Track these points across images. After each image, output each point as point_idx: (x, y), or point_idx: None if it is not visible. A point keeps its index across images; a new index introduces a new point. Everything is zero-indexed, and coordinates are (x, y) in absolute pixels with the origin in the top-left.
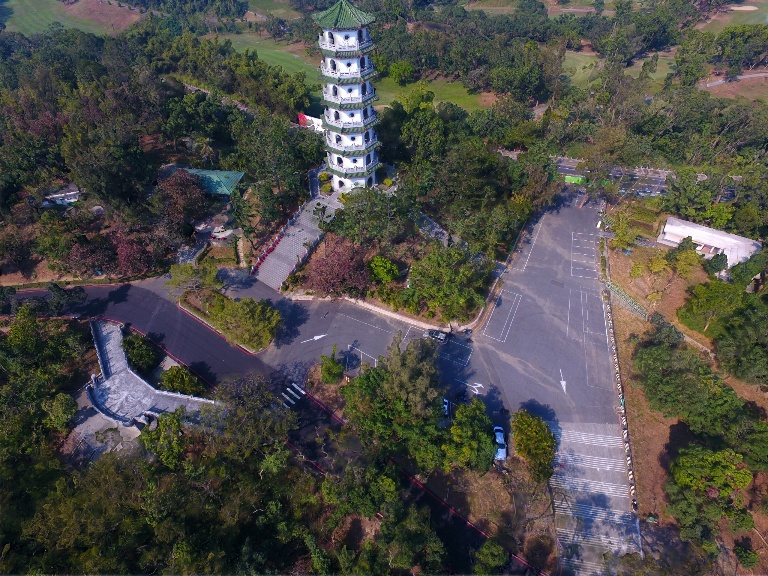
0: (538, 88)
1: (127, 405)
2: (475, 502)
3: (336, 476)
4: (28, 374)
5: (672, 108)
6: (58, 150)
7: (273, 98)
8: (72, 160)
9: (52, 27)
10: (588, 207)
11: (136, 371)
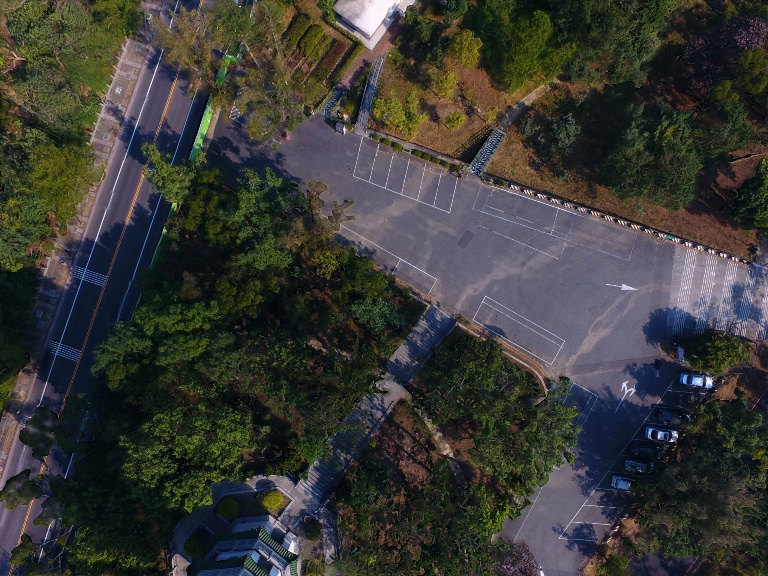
0: None
1: None
2: None
3: None
4: None
5: None
6: None
7: None
8: None
9: None
10: None
11: None
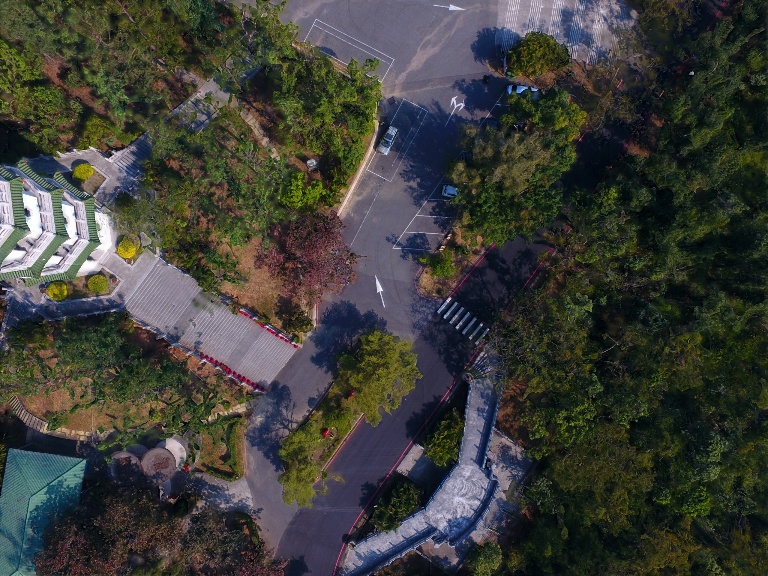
0: None
1: (472, 492)
2: (623, 117)
3: (597, 246)
4: None
5: None
6: None
7: None
8: None
9: None
10: None
11: None
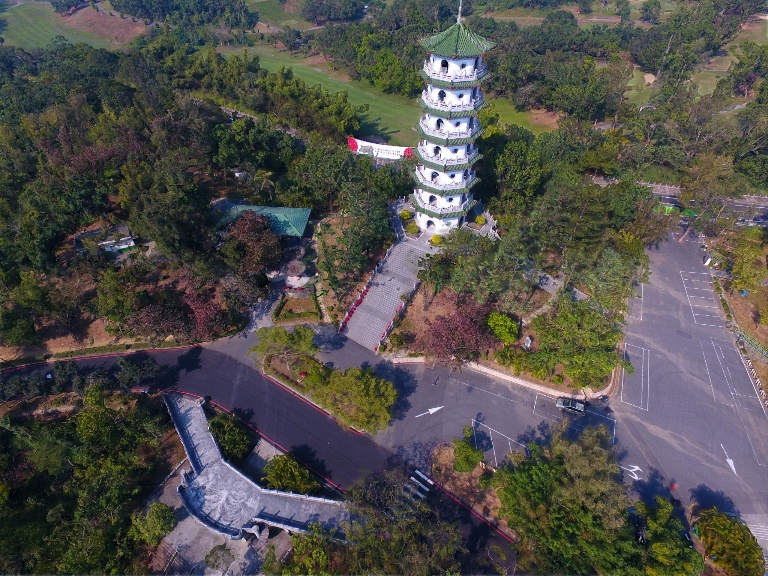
0: (598, 106)
1: (230, 510)
2: None
3: None
4: (96, 465)
5: (752, 128)
6: (107, 191)
7: (318, 120)
8: (129, 204)
9: (55, 41)
10: (687, 240)
11: (229, 460)
